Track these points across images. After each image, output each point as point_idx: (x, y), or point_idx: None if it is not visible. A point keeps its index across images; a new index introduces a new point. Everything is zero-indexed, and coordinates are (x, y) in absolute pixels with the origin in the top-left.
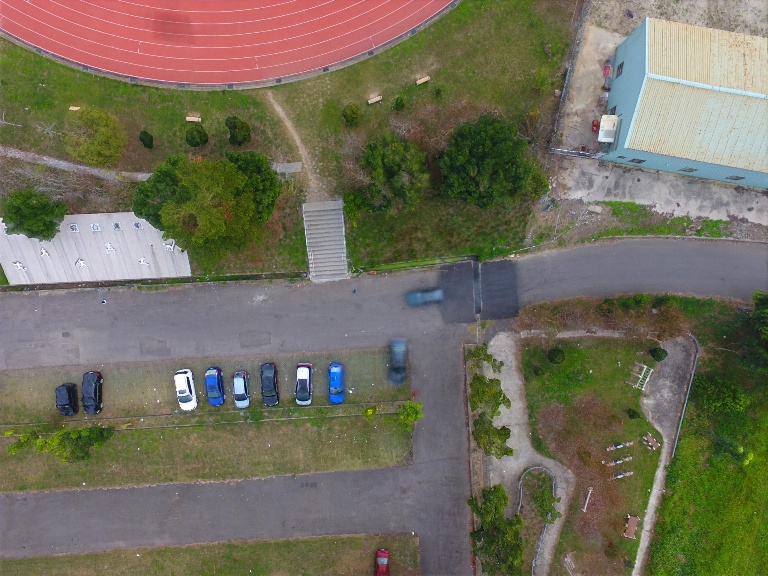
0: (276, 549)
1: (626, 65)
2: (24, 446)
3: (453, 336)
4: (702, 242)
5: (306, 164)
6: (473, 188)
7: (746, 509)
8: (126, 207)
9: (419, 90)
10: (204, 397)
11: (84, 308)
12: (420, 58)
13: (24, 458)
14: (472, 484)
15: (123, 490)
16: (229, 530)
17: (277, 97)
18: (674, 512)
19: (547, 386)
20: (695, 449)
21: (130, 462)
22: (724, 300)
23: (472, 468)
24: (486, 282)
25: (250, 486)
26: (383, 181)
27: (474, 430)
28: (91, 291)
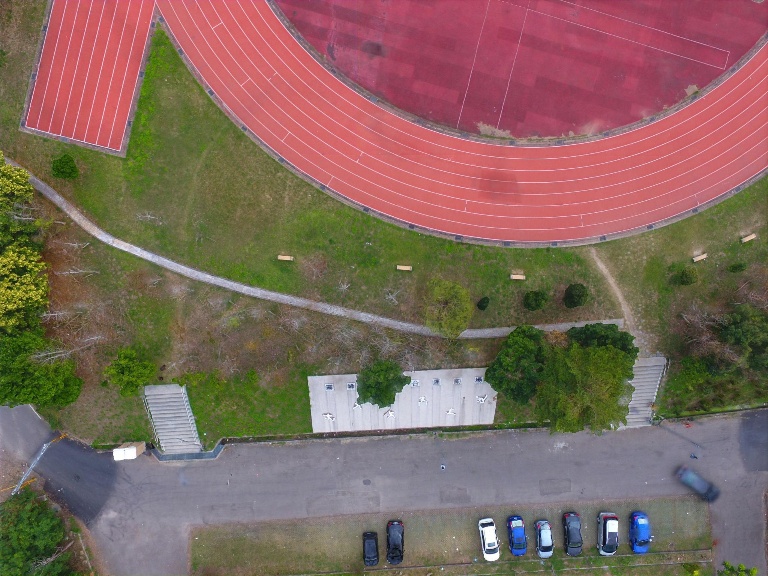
0: None
1: None
2: None
3: (754, 484)
4: None
5: (628, 320)
6: None
7: None
8: (448, 364)
9: (743, 247)
10: (503, 545)
11: (385, 456)
12: (744, 215)
13: None
14: None
15: None
16: None
17: (600, 254)
18: None
19: None
20: None
21: None
22: None
23: None
24: None
25: None
26: None
27: None
28: (393, 439)
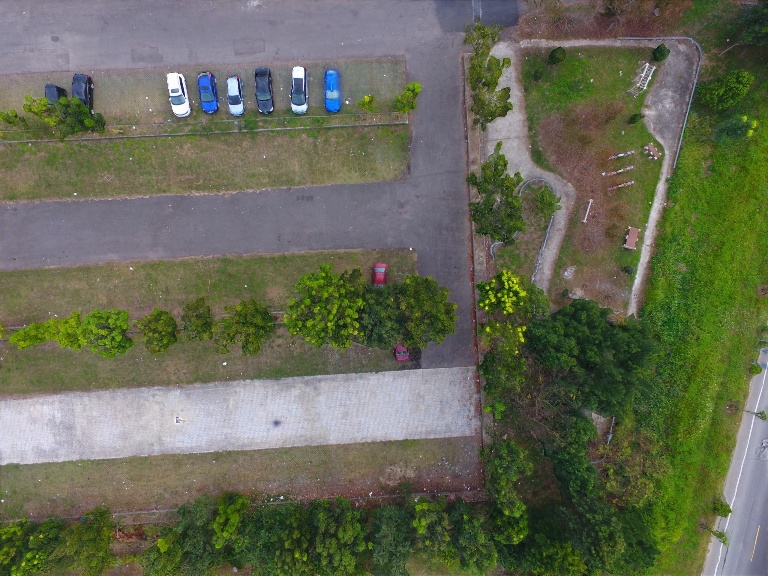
0: (272, 264)
1: None
2: (12, 119)
3: (452, 45)
4: None
5: None
6: None
7: (748, 206)
8: None
9: None
10: (197, 106)
11: (73, 11)
12: None
13: (13, 166)
14: (471, 197)
15: (115, 201)
16: (224, 244)
17: None
18: (675, 221)
19: (547, 97)
20: (697, 157)
21: (122, 172)
22: None
23: None
24: None
25: (245, 198)
26: None
27: (473, 104)
28: None
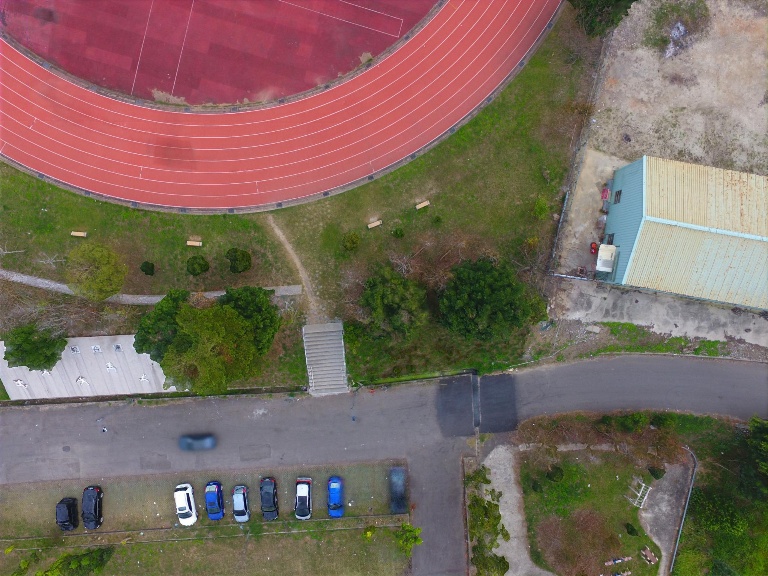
0: None
1: (624, 196)
2: (24, 573)
3: (452, 449)
4: (700, 360)
5: (306, 287)
6: (472, 327)
7: None
8: (127, 329)
9: (418, 214)
10: (204, 510)
11: (85, 422)
12: (420, 182)
13: None
14: None
15: None
16: None
17: (277, 221)
18: None
19: (546, 499)
20: (693, 564)
21: (130, 575)
22: (722, 418)
23: None
24: (485, 396)
25: None
26: (383, 318)
27: (473, 557)
28: (92, 405)
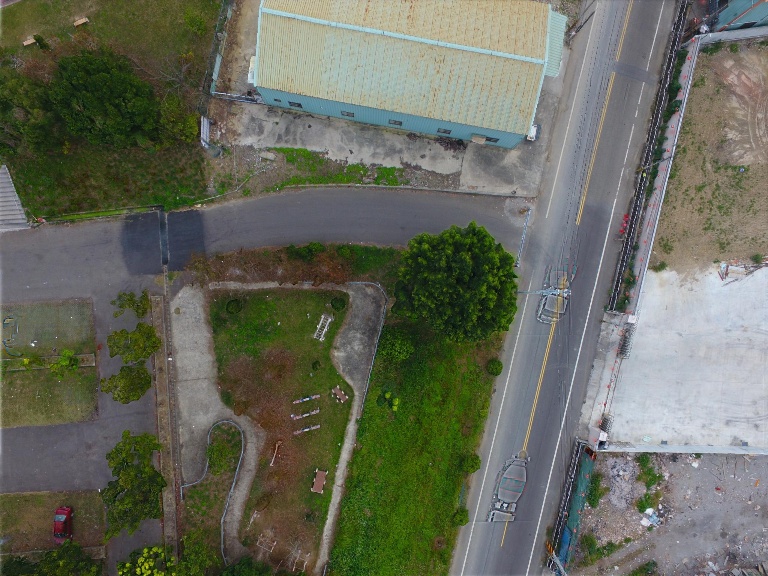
0: None
1: None
2: None
3: (139, 288)
4: (383, 191)
5: None
6: (89, 124)
7: (421, 460)
8: None
9: (78, 32)
10: None
11: None
12: None
13: None
14: (159, 439)
15: None
16: None
17: None
18: (361, 466)
19: (235, 339)
20: None
21: None
22: (404, 249)
23: (159, 423)
24: (173, 233)
25: None
26: (2, 118)
27: None
28: None
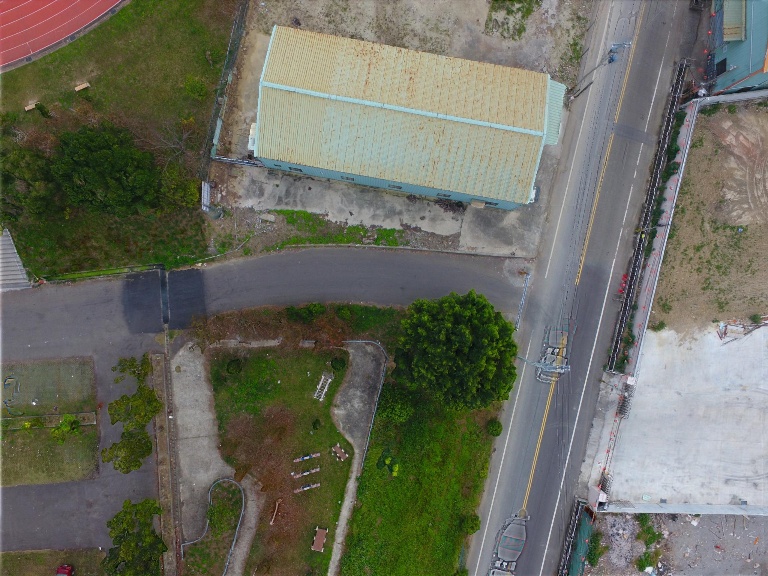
0: None
1: None
2: None
3: (140, 346)
4: (382, 251)
5: None
6: (91, 197)
7: (421, 521)
8: None
9: (79, 97)
10: None
11: None
12: (80, 64)
13: None
14: (160, 497)
15: None
16: None
17: None
18: (361, 524)
19: (236, 397)
20: None
21: None
22: (404, 309)
23: (160, 481)
24: (173, 291)
25: None
26: (4, 189)
27: None
28: None
